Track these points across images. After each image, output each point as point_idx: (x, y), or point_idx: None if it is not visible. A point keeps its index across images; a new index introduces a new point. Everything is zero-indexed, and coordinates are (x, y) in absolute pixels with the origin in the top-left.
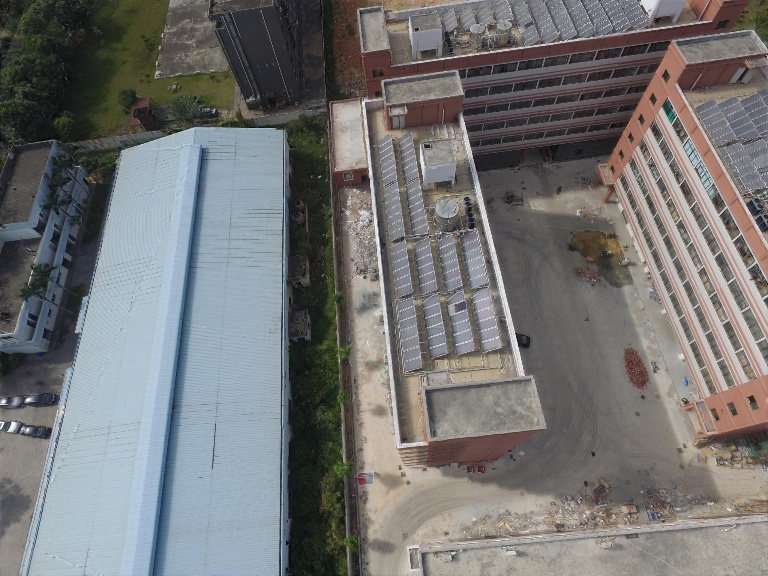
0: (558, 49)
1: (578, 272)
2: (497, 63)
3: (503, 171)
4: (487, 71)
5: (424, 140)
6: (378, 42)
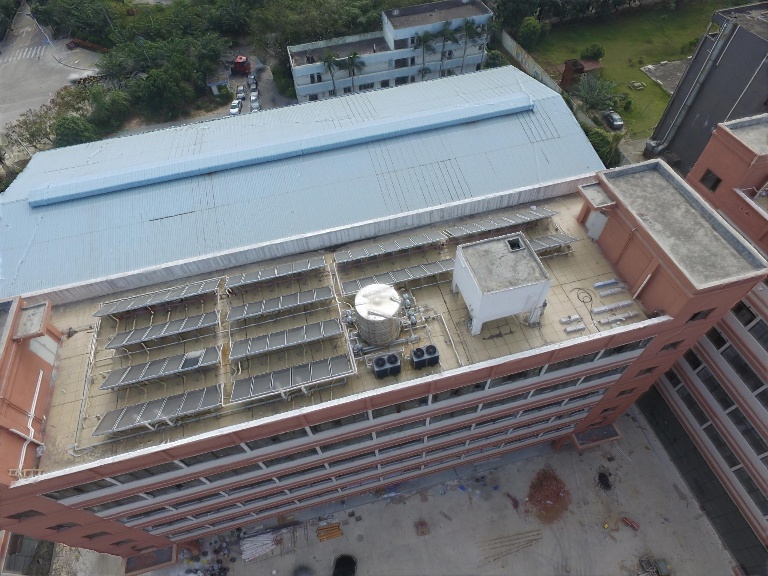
0: None
1: None
2: None
3: (721, 550)
4: None
5: (576, 273)
6: None
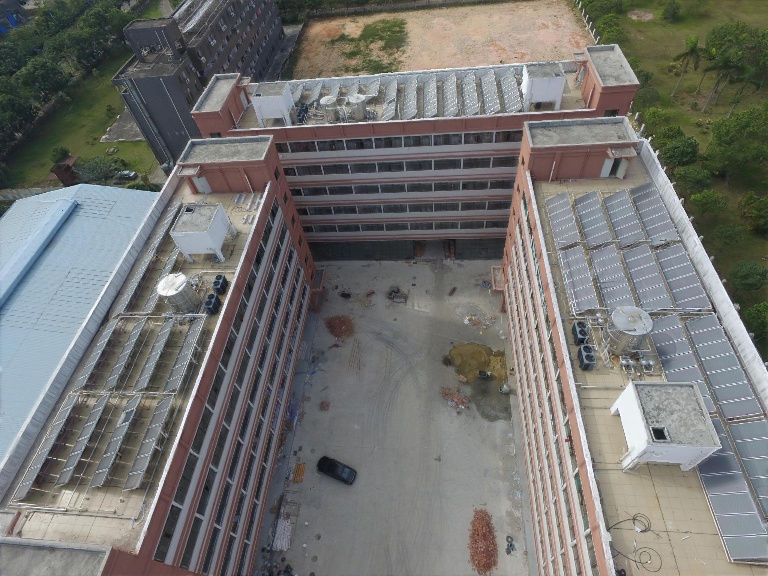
0: (415, 127)
1: (445, 393)
2: (348, 137)
3: (397, 263)
4: (341, 146)
5: None
6: (217, 105)
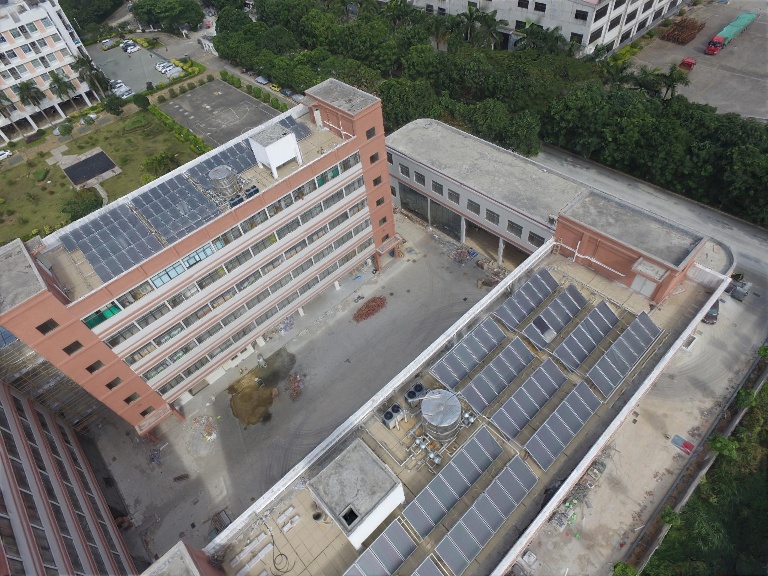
0: None
1: (297, 395)
2: None
3: None
4: None
5: None
6: None
